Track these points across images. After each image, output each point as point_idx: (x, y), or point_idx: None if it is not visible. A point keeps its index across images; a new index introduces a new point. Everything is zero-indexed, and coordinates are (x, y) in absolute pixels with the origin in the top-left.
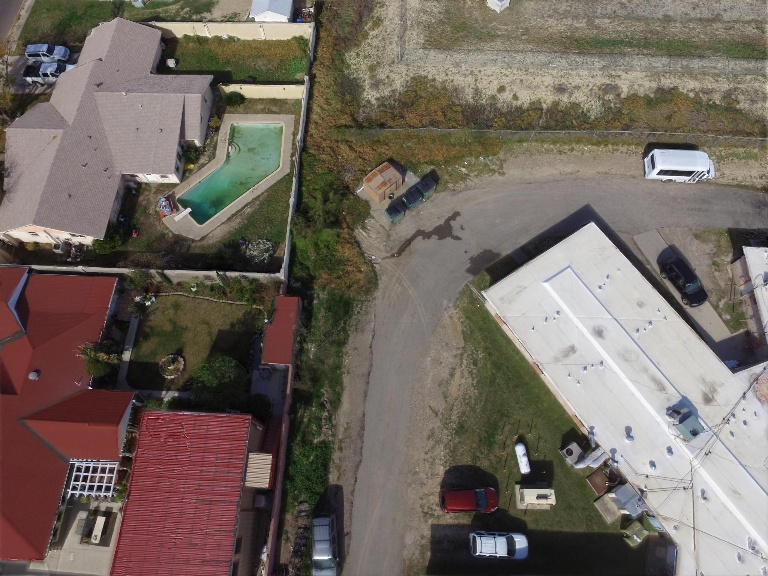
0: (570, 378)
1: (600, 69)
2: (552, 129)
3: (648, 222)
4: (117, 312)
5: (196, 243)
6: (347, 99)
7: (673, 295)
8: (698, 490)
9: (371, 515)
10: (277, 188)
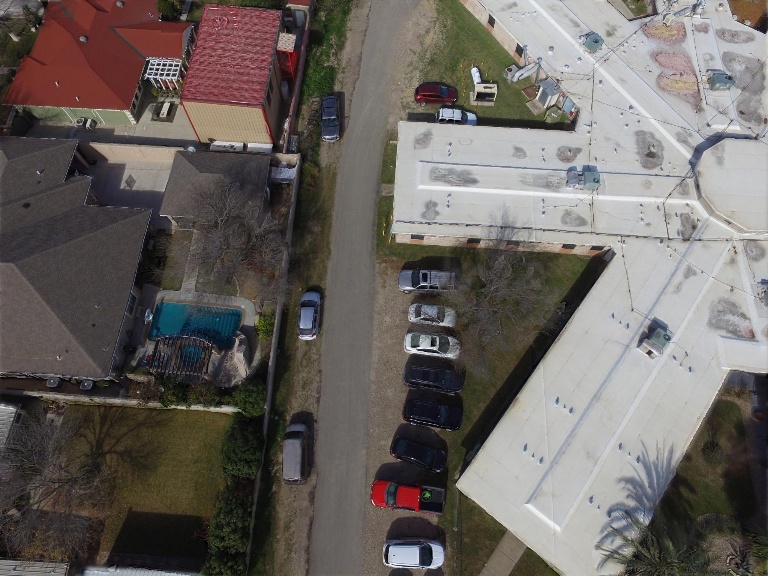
0: (512, 19)
1: None
2: None
3: None
4: None
5: None
6: None
7: None
8: (597, 80)
9: (365, 106)
10: None
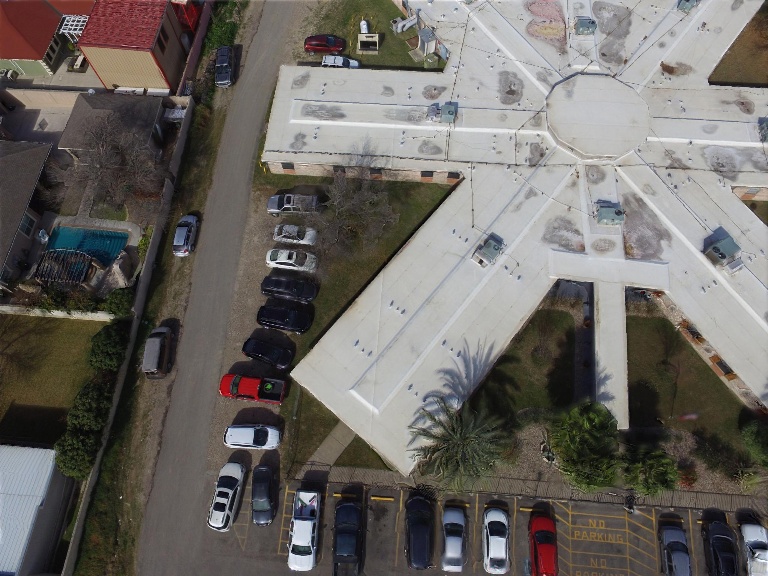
0: None
1: None
2: None
3: None
4: None
5: None
6: None
7: None
8: (470, 28)
9: (259, 57)
10: None
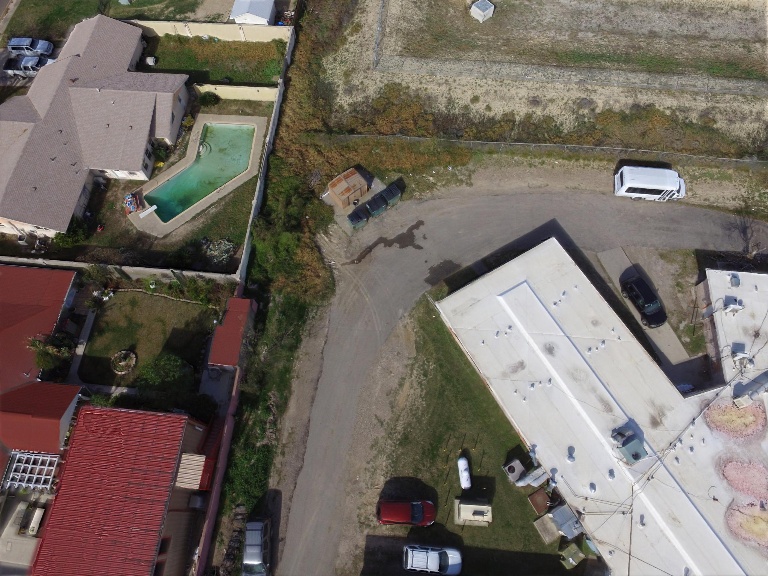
0: (516, 394)
1: (576, 83)
2: (523, 141)
3: (614, 239)
4: (75, 305)
5: (159, 241)
6: (320, 103)
7: (633, 315)
8: (637, 516)
9: (307, 522)
10: (243, 189)
